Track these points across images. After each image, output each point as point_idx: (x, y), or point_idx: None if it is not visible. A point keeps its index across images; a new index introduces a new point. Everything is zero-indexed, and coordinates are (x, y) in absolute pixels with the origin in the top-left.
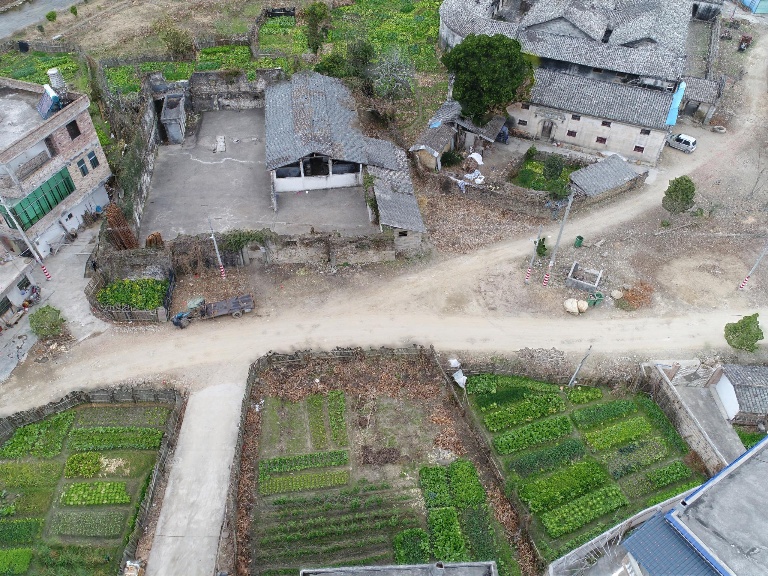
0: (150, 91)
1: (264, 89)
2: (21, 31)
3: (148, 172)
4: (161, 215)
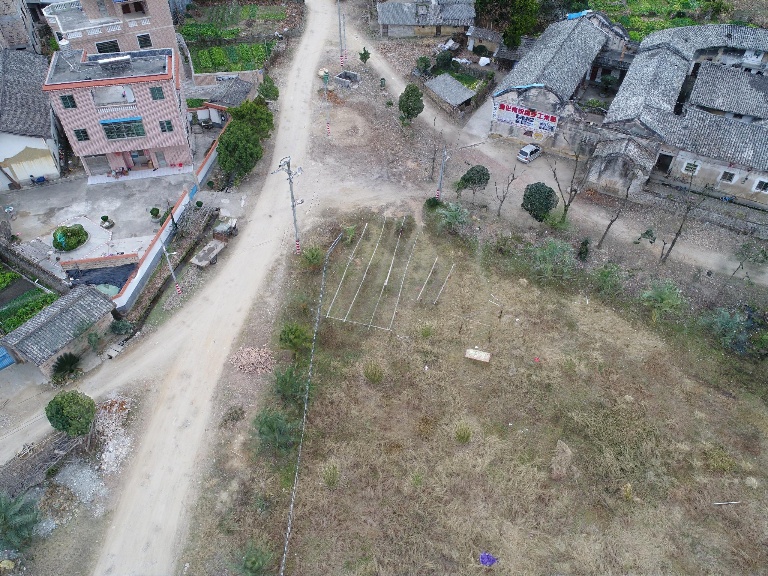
0: None
1: None
2: None
3: None
4: None
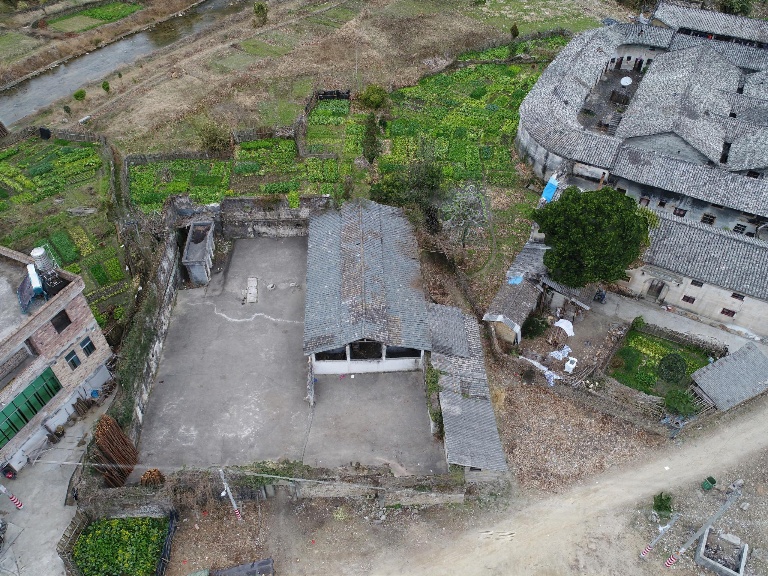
0: (174, 217)
1: (308, 217)
2: (47, 109)
3: (161, 336)
4: (170, 404)
